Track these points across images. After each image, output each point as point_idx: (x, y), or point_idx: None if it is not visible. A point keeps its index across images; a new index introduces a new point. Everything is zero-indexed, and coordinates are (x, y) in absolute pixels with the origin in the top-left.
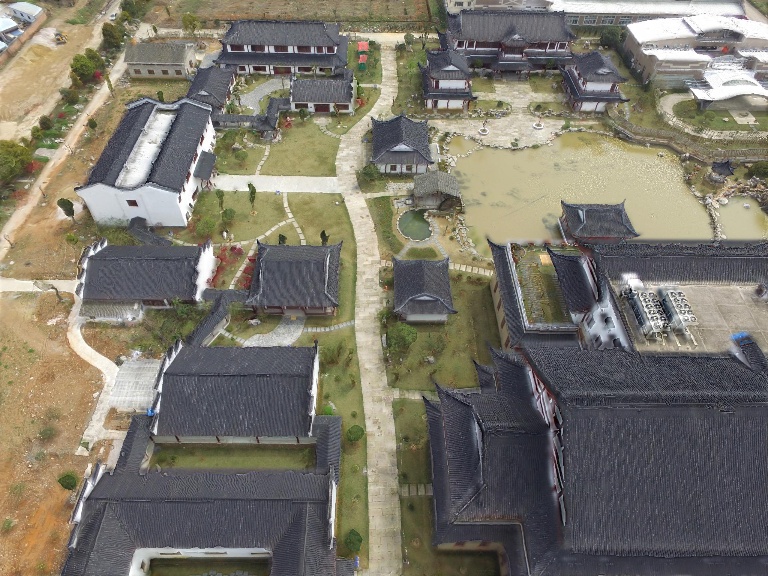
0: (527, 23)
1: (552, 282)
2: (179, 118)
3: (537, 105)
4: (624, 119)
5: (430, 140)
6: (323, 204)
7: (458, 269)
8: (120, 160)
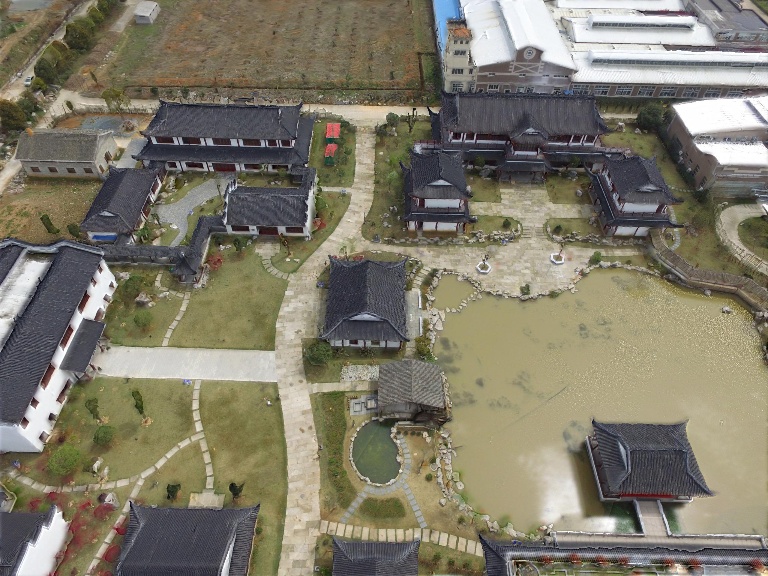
0: (544, 110)
1: None
2: (50, 274)
3: (556, 225)
4: (675, 255)
5: (410, 284)
6: (249, 404)
7: (436, 543)
8: None
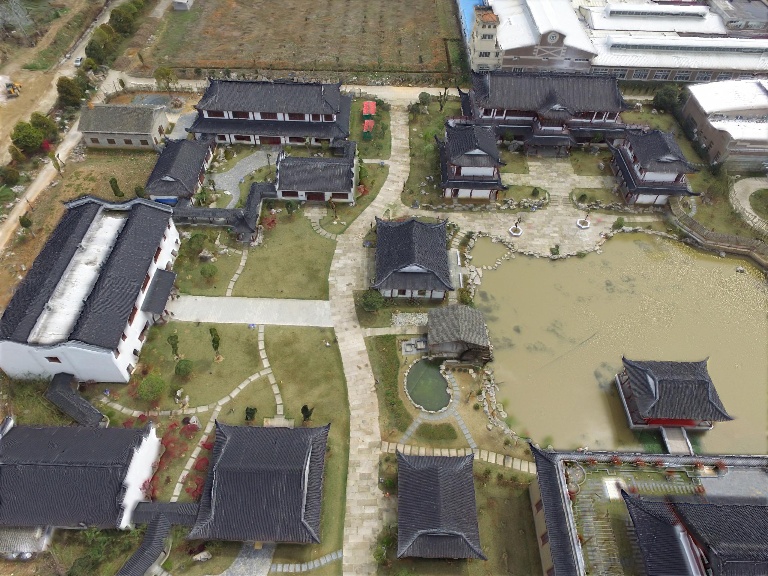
0: (570, 88)
1: (627, 537)
2: (128, 227)
3: (581, 194)
4: (693, 220)
5: (449, 244)
6: (309, 345)
7: (485, 460)
8: (41, 298)
